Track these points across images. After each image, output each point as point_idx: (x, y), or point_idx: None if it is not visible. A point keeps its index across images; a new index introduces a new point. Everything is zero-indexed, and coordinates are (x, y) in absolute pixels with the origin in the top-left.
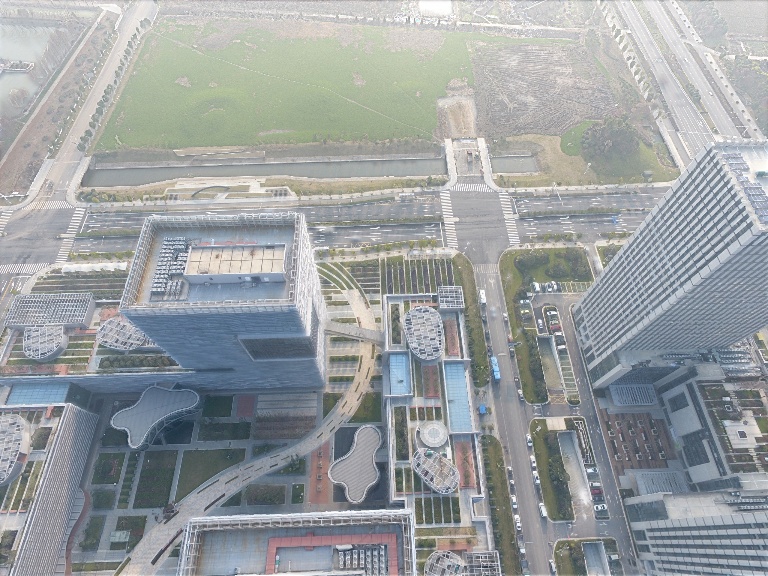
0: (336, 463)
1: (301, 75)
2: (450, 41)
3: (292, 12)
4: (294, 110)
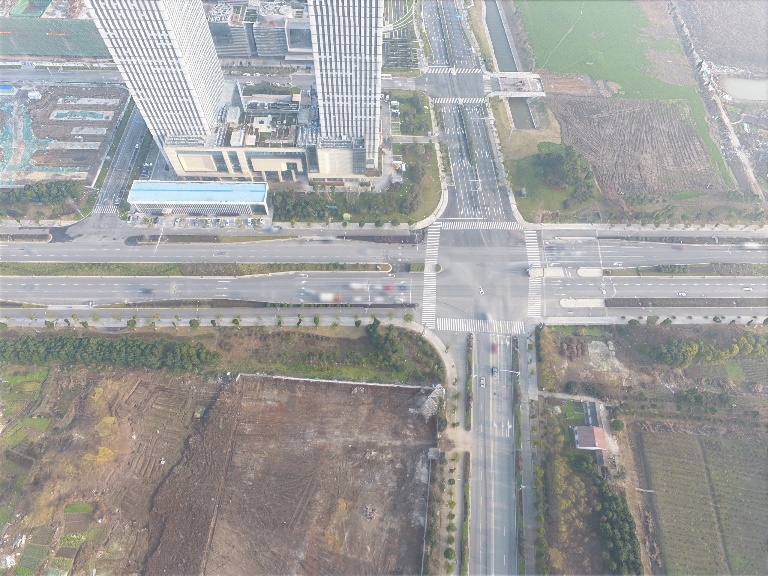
0: (284, 1)
1: (592, 8)
2: (679, 88)
3: (677, 5)
4: (550, 6)
